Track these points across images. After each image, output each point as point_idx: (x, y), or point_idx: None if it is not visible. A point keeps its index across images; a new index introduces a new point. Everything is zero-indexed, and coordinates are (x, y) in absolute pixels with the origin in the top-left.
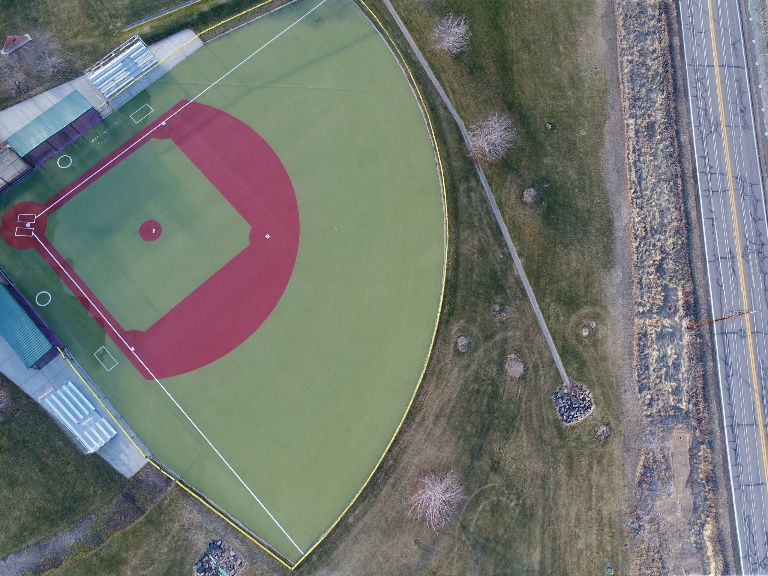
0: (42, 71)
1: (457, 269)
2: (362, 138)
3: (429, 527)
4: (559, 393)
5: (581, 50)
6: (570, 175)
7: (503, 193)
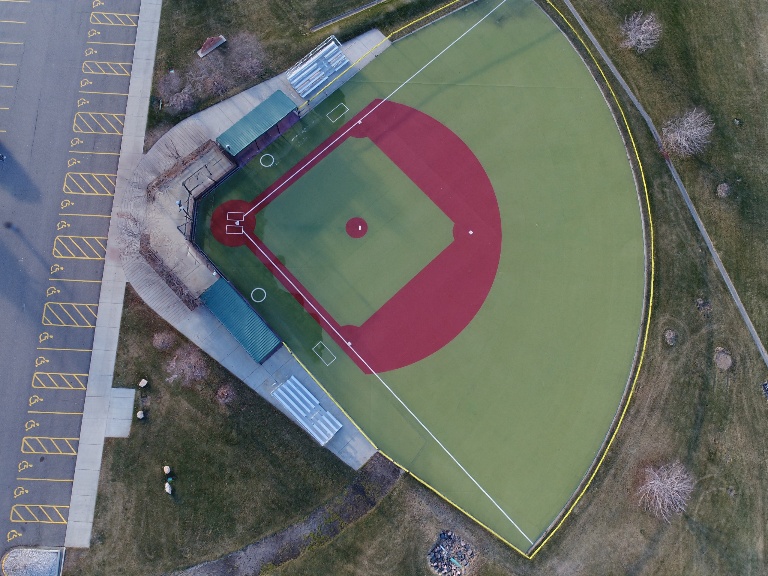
0: (238, 72)
1: (658, 263)
2: (554, 135)
3: (653, 517)
4: (767, 385)
5: (762, 46)
6: (762, 170)
7: (696, 188)
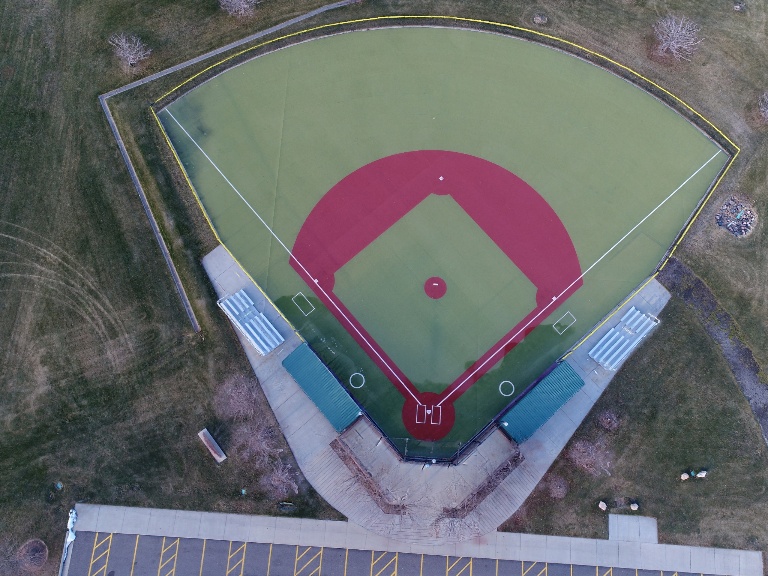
0: (246, 414)
1: None
2: (340, 93)
3: None
4: None
5: None
6: None
7: None
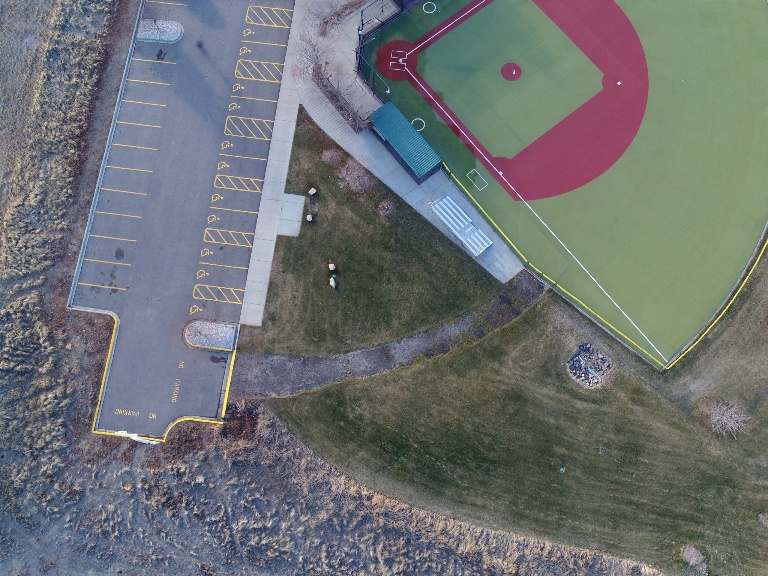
0: None
1: None
2: (703, 1)
3: None
4: None
5: None
6: None
7: None
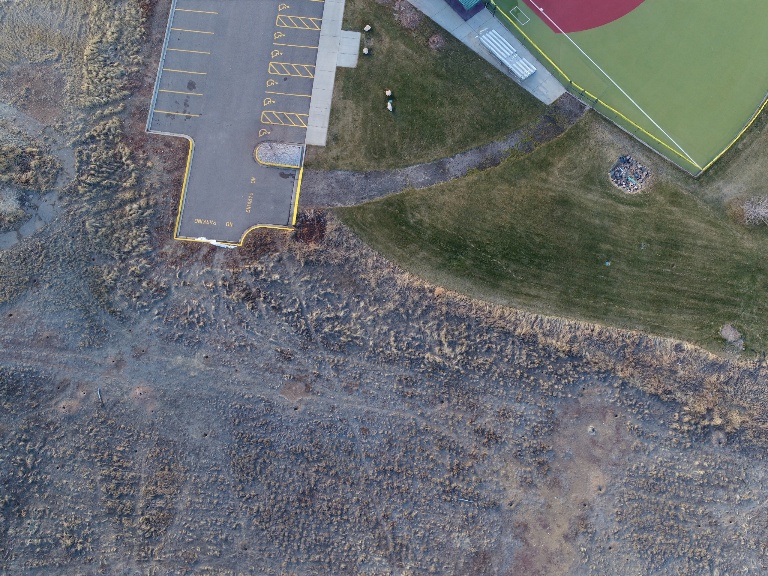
0: None
1: None
2: None
3: None
4: None
5: None
6: None
7: None
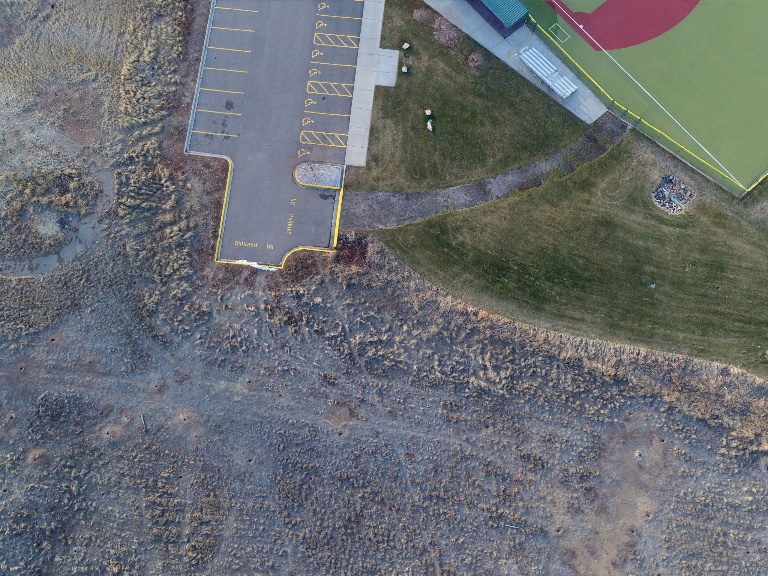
0: None
1: None
2: None
3: None
4: None
5: None
6: None
7: None
